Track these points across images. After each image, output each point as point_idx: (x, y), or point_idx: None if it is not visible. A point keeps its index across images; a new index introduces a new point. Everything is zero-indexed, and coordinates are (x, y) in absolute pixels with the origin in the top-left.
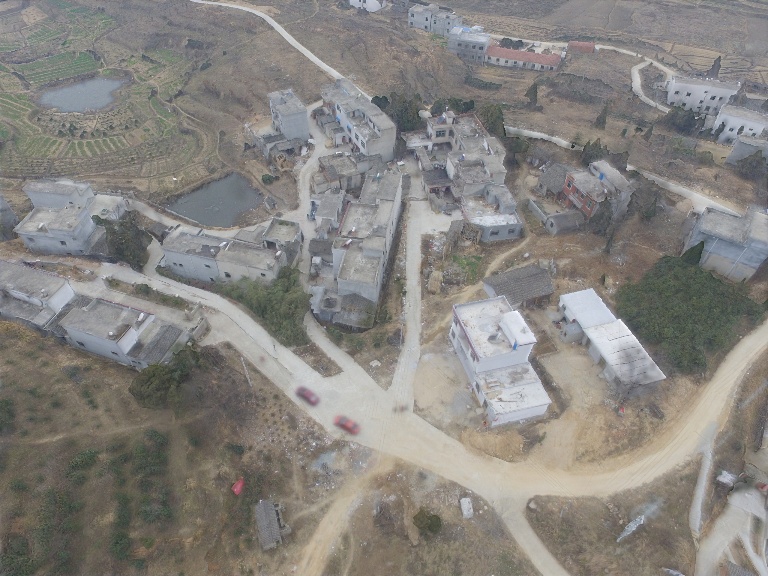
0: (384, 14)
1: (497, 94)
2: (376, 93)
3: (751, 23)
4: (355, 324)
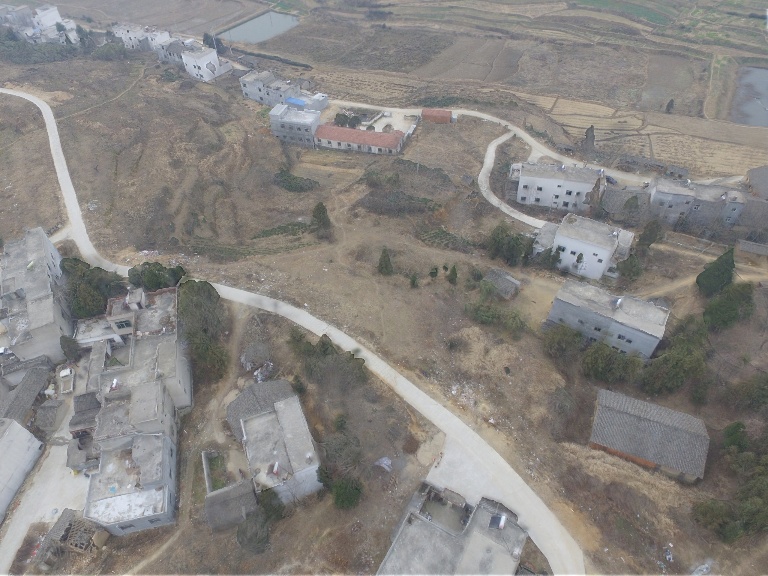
0: (218, 83)
1: (304, 200)
2: (102, 234)
3: (653, 63)
4: None
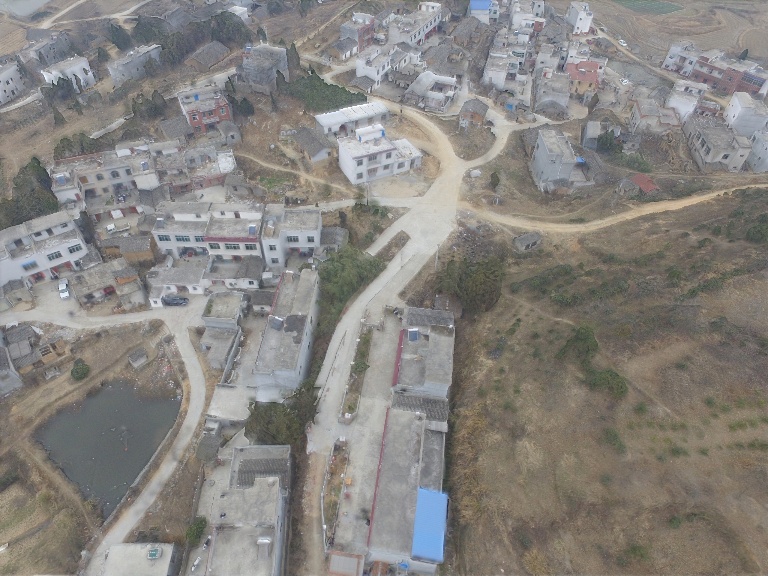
0: None
1: None
2: None
3: None
4: (346, 238)
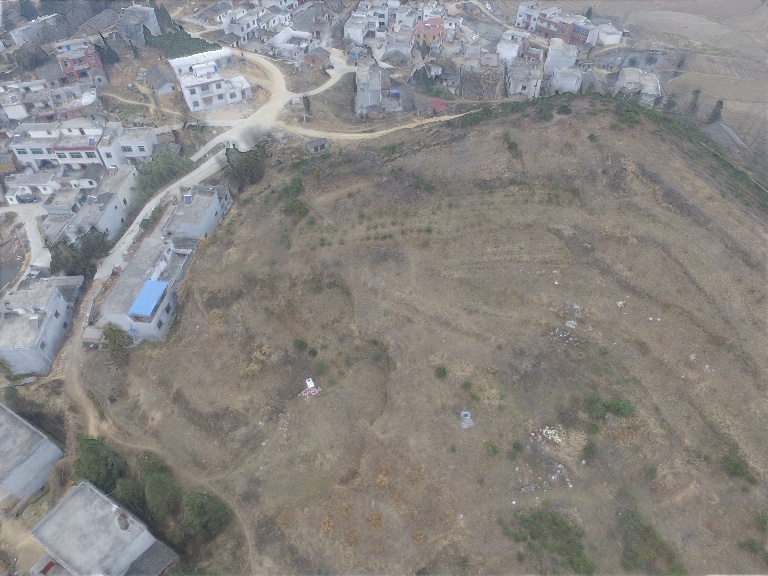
0: None
1: None
2: None
3: None
4: (177, 151)
